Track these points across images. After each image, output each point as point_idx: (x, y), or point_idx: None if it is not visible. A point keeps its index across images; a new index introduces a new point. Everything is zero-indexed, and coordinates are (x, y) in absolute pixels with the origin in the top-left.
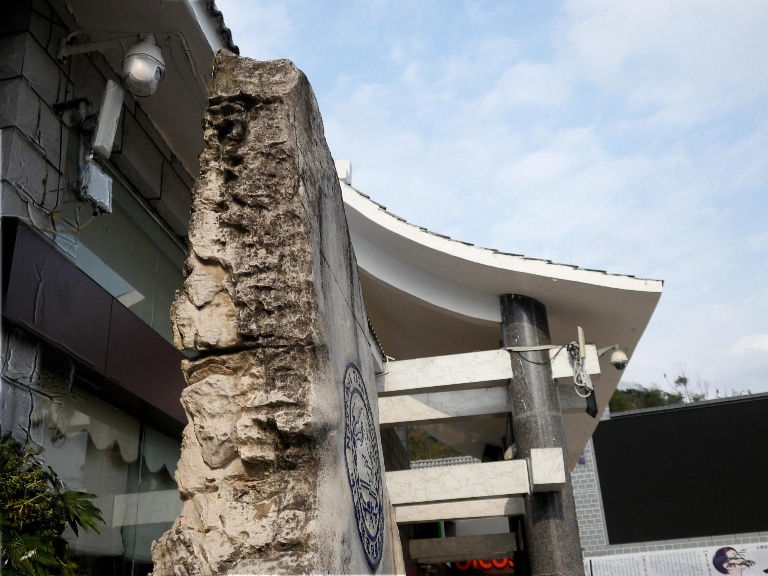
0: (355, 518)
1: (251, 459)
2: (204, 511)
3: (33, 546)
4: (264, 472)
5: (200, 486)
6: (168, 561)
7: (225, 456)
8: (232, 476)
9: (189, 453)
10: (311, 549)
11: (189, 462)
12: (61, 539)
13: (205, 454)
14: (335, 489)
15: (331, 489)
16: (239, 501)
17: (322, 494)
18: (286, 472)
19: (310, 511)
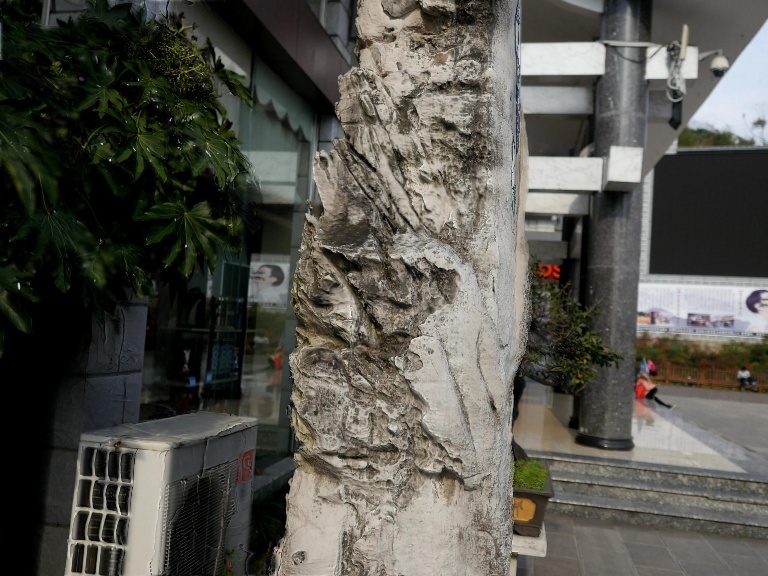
0: (516, 89)
1: (432, 9)
2: (382, 57)
3: (192, 111)
4: (441, 26)
5: (378, 35)
6: (353, 92)
7: (406, 5)
8: (410, 27)
9: (369, 2)
10: (488, 92)
11: (369, 11)
12: (210, 115)
13: (386, 3)
14: (506, 52)
15: (503, 50)
16: (415, 52)
17: (496, 51)
18: (464, 27)
19: (486, 63)
